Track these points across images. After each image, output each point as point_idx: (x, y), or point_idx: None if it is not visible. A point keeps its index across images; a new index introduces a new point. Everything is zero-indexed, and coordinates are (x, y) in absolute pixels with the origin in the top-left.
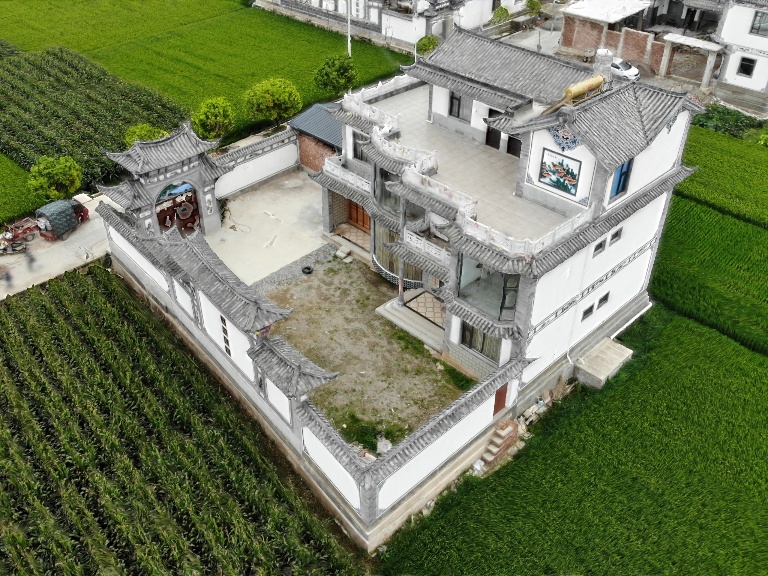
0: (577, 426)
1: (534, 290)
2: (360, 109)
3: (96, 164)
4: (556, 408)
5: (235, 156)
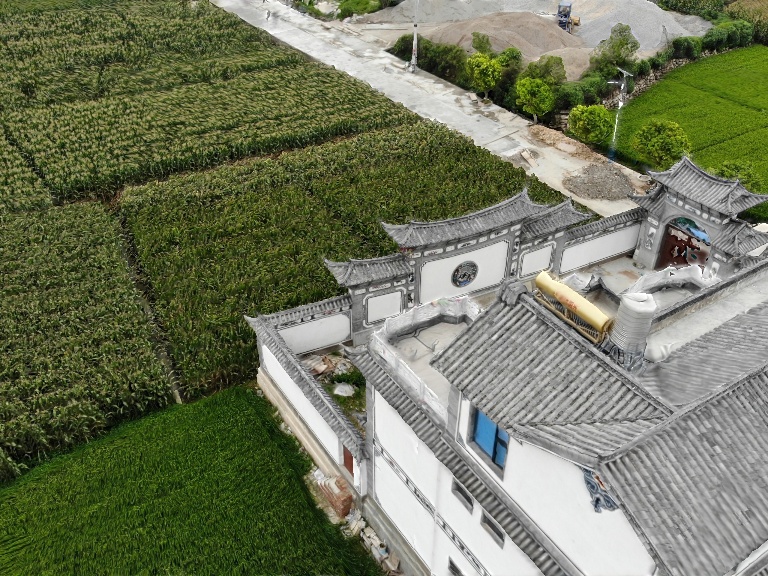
0: (332, 571)
1: (372, 390)
2: None
3: None
4: (377, 572)
5: None
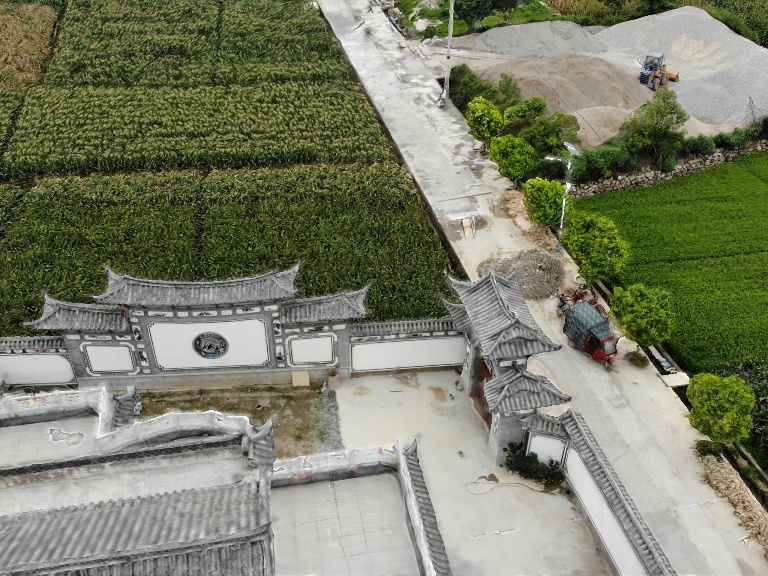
0: None
1: None
2: (355, 458)
3: (761, 398)
4: None
5: (594, 468)
